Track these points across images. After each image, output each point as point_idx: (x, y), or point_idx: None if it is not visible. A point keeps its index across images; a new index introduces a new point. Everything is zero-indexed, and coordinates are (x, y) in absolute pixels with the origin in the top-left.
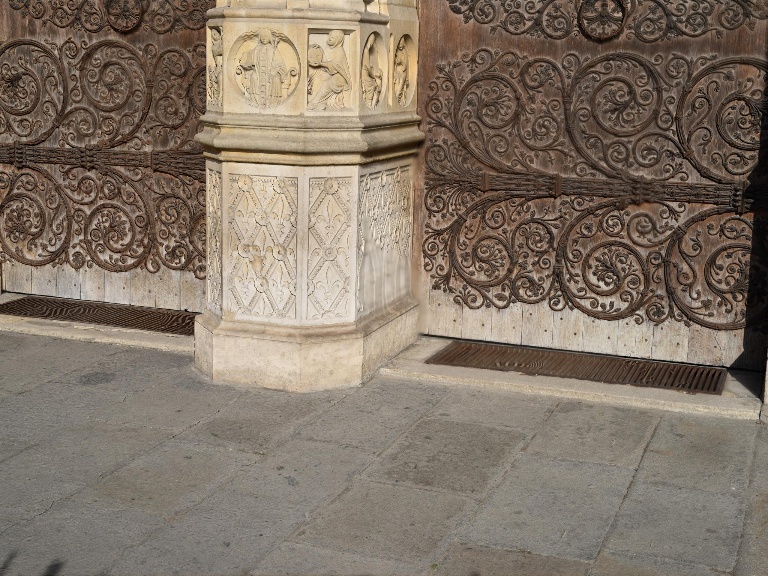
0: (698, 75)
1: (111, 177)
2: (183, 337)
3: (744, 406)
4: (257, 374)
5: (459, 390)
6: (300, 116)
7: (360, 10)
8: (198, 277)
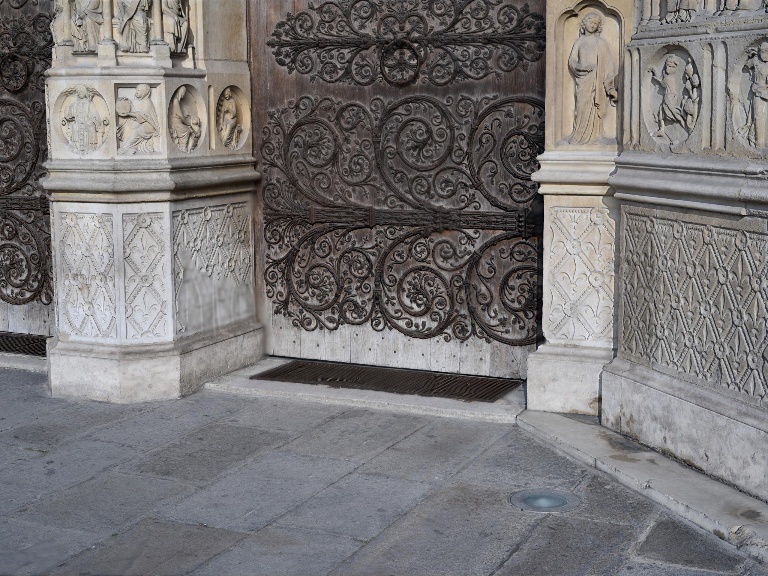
0: (482, 114)
1: (10, 220)
2: None
3: (505, 411)
4: (86, 388)
5: (266, 401)
6: (111, 160)
7: (167, 66)
8: None
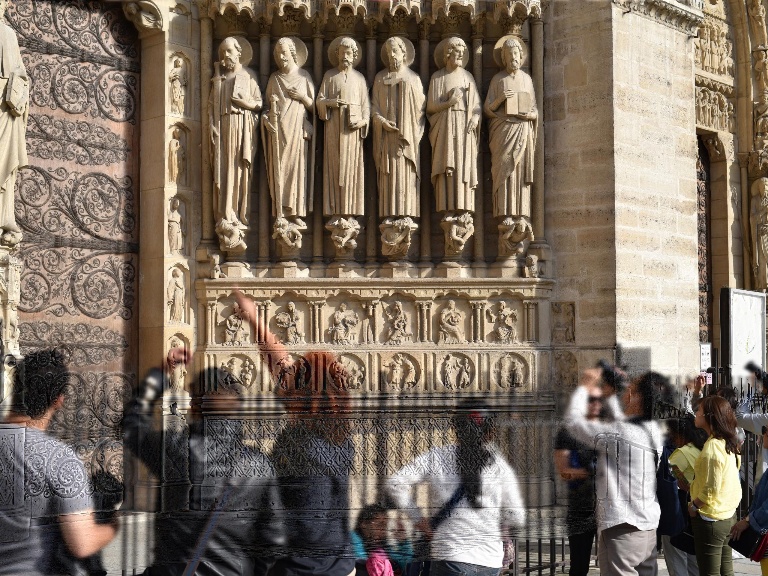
0: None
1: None
2: None
3: None
4: None
5: (62, 531)
6: (16, 405)
7: None
8: None
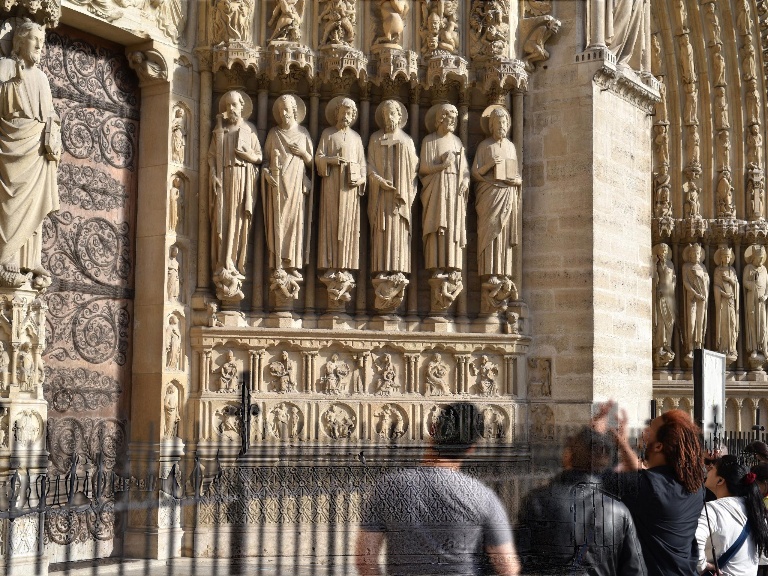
0: None
1: None
2: None
3: None
4: None
5: None
6: (43, 450)
7: None
8: None
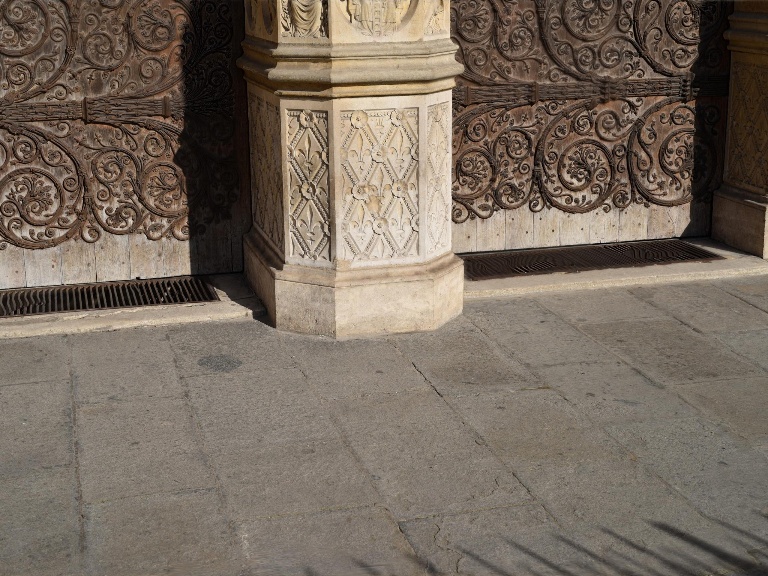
0: None
1: (26, 136)
2: (208, 304)
3: (759, 263)
4: (386, 321)
5: (539, 298)
6: (419, 42)
7: None
8: (152, 238)
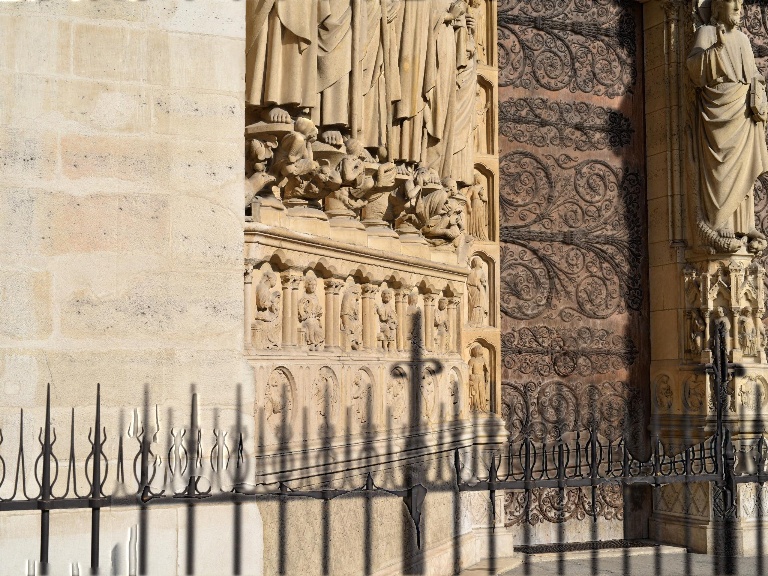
0: None
1: None
2: None
3: None
4: (764, 548)
5: None
6: None
7: None
8: (608, 519)
